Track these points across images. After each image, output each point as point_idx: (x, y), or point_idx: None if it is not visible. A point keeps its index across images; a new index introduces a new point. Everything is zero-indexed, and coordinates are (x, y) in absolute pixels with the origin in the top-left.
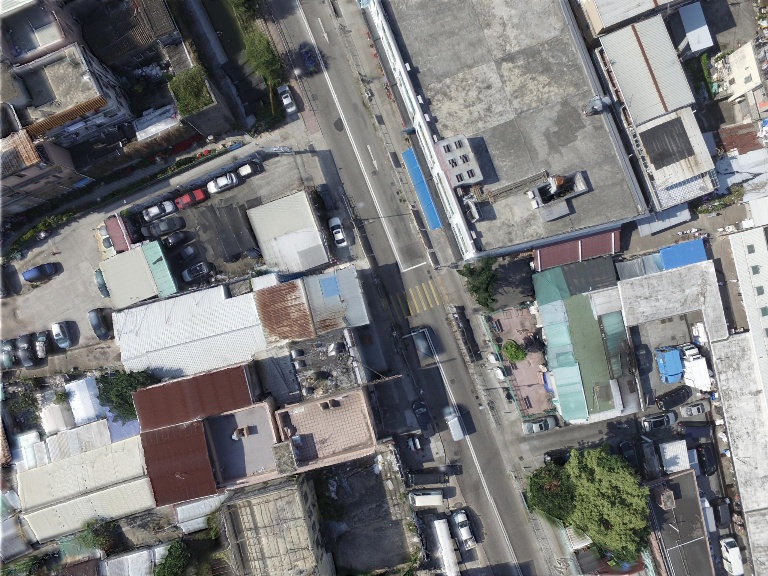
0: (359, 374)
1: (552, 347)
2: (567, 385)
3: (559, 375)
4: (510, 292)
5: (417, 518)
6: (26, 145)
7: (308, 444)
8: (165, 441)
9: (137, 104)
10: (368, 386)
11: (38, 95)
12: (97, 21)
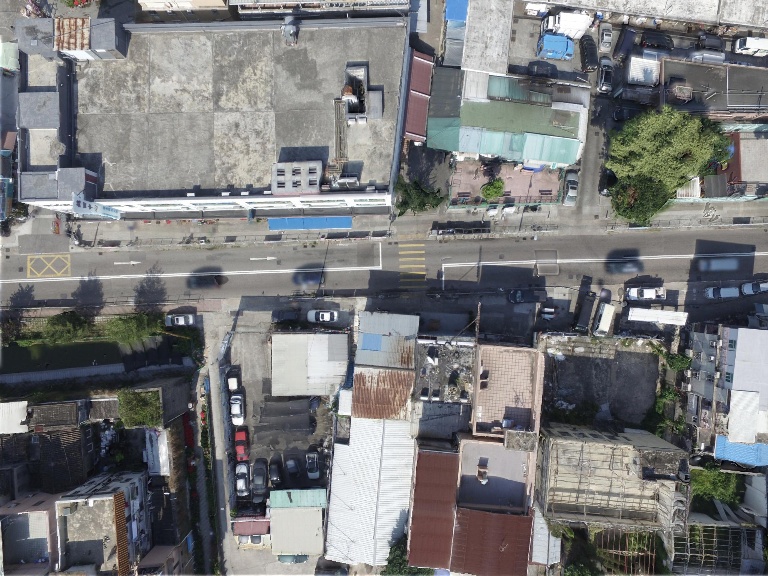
0: (465, 342)
1: (501, 152)
2: (542, 150)
3: (530, 154)
4: (436, 173)
5: (619, 335)
6: None
7: (515, 414)
8: (465, 550)
9: (134, 465)
10: (479, 338)
11: (92, 556)
12: (42, 475)
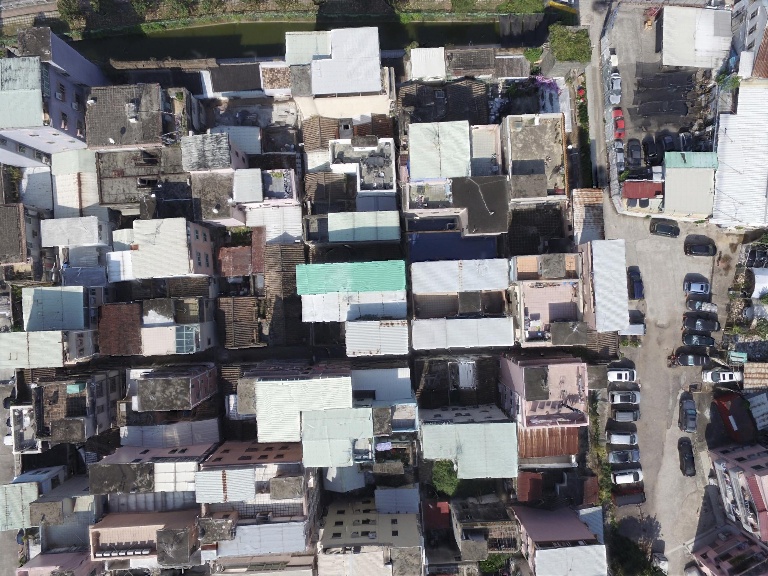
0: None
1: None
2: None
3: None
4: None
5: None
6: (587, 195)
7: None
8: None
9: None
10: None
11: None
12: None
